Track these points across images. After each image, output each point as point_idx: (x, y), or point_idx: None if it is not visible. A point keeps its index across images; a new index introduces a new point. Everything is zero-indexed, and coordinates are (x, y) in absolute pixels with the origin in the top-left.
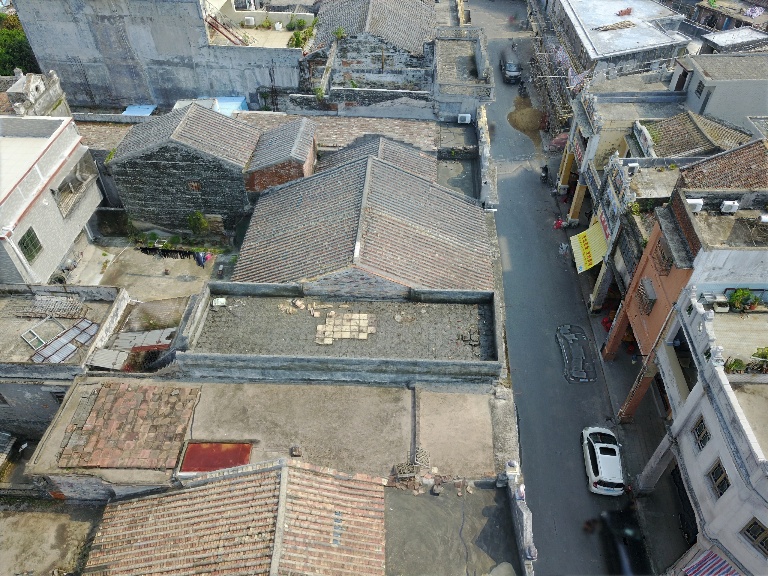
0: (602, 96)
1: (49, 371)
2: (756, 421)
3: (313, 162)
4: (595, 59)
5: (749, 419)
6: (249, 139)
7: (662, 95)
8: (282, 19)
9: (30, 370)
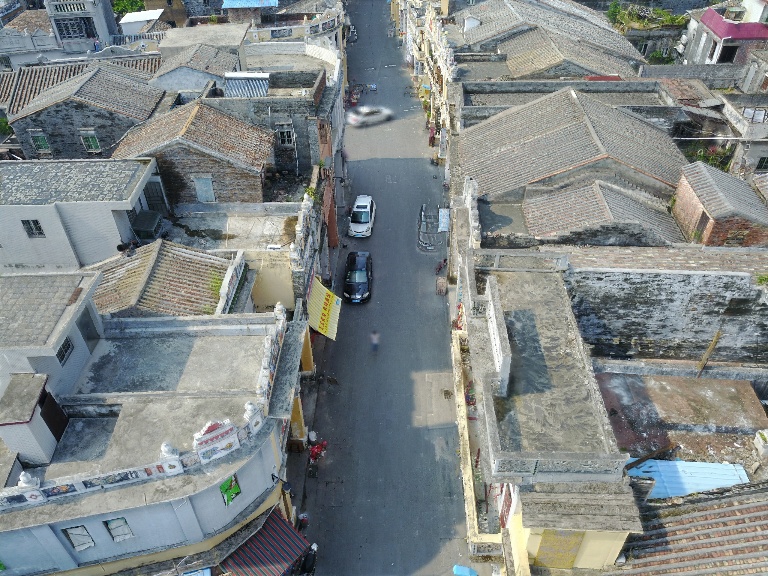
0: None
1: None
2: None
3: (692, 232)
4: None
5: None
6: None
7: None
8: None
9: None
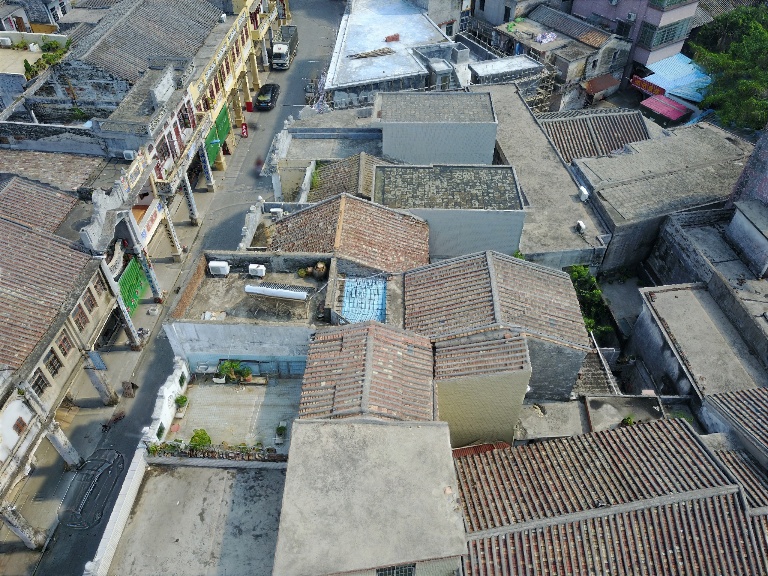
0: (302, 131)
1: None
2: (157, 510)
3: None
4: (328, 89)
5: (152, 507)
6: None
7: (364, 132)
8: (38, 40)
9: None
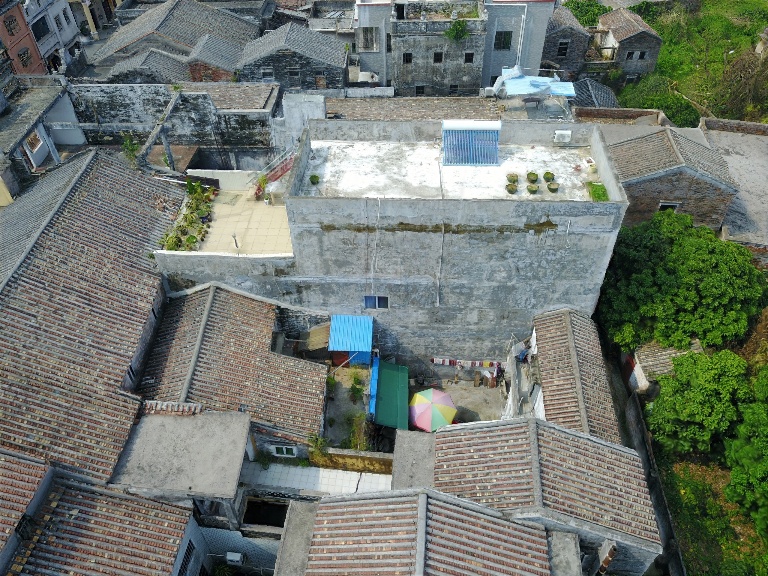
0: None
1: (330, 5)
2: None
3: None
4: None
5: None
6: (243, 57)
7: None
8: None
9: (338, 5)
